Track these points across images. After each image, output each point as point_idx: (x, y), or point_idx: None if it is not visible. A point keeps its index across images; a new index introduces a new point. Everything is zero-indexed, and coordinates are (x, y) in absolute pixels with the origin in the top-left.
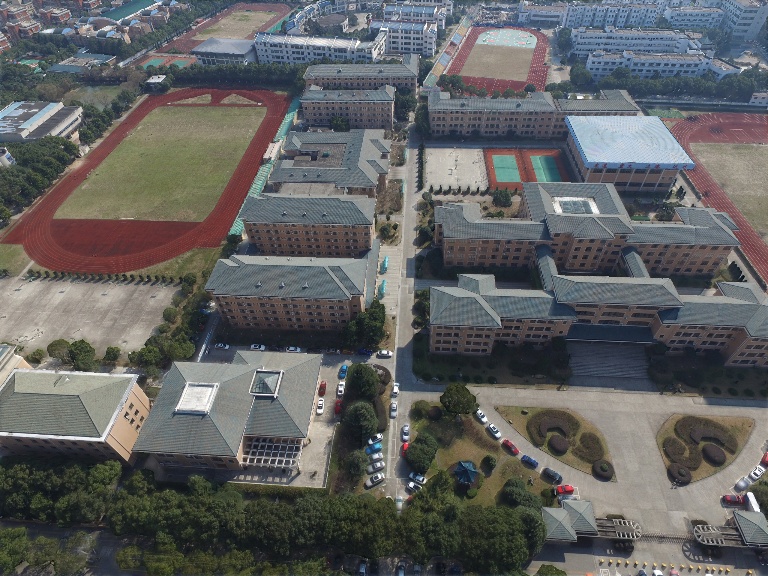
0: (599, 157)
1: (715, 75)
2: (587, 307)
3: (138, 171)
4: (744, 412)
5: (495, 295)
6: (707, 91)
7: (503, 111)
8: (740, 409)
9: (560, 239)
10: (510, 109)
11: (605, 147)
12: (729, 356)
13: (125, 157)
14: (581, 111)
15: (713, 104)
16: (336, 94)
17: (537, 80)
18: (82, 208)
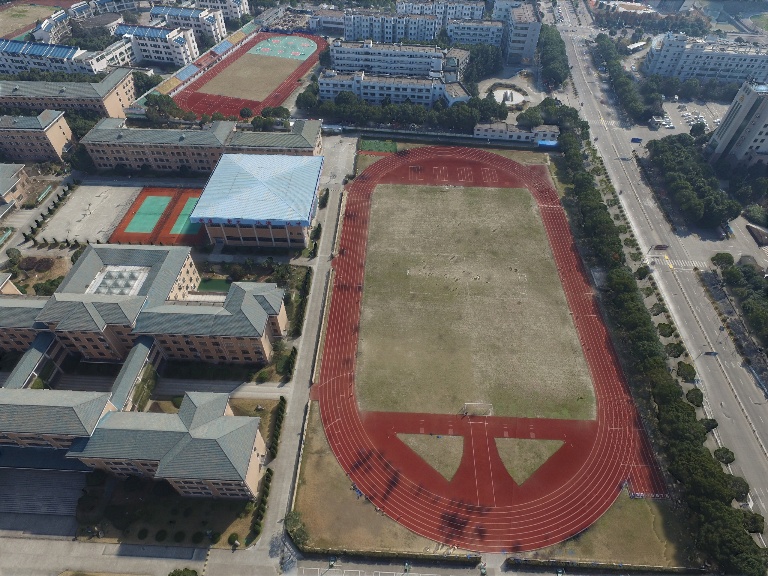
0: (207, 210)
1: (447, 102)
2: None
3: None
4: (153, 566)
5: None
6: (429, 121)
7: (163, 145)
8: (151, 562)
9: None
10: (171, 143)
11: (225, 197)
12: None
13: None
14: (249, 147)
15: (438, 135)
16: None
17: (275, 100)
18: None
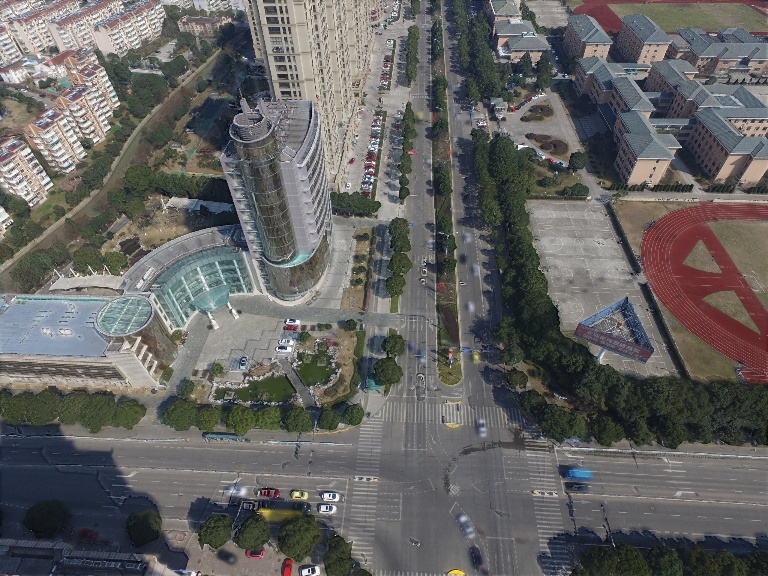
0: None
1: None
2: None
3: (663, 12)
4: None
5: None
6: None
7: None
8: None
9: None
10: None
11: None
12: None
13: (674, 7)
14: None
15: None
16: None
17: None
18: (619, 7)
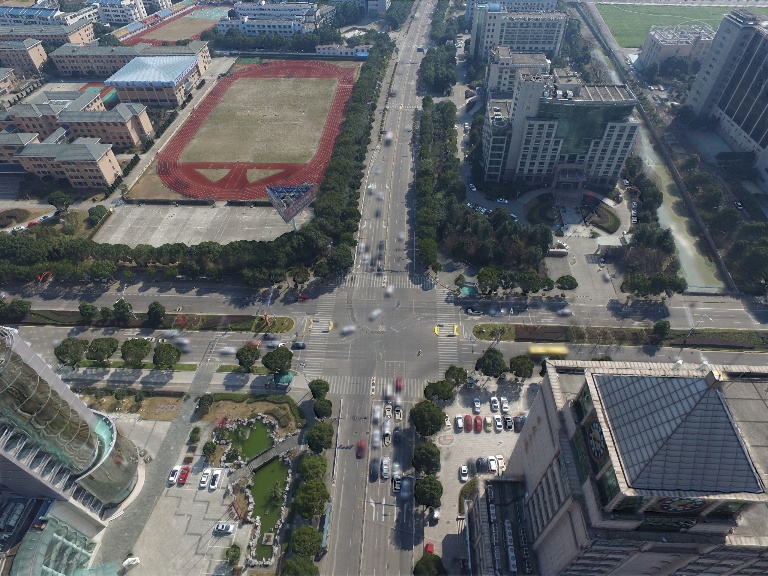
0: (115, 79)
1: None
2: None
3: None
4: (53, 207)
5: None
6: (286, 44)
7: (101, 55)
8: (52, 206)
9: (18, 120)
10: (106, 53)
11: (128, 73)
12: (69, 180)
13: None
14: (154, 54)
15: (293, 55)
16: None
17: None
18: None
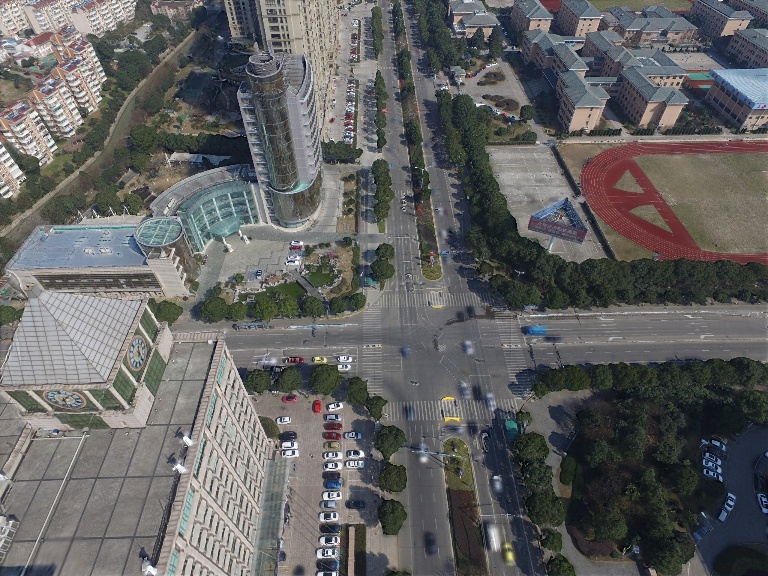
0: (723, 73)
1: None
2: (556, 57)
3: None
4: None
5: (547, 36)
6: None
7: (767, 52)
8: None
9: None
10: None
11: (742, 75)
12: None
13: None
14: None
15: None
16: (713, 1)
17: None
18: None
